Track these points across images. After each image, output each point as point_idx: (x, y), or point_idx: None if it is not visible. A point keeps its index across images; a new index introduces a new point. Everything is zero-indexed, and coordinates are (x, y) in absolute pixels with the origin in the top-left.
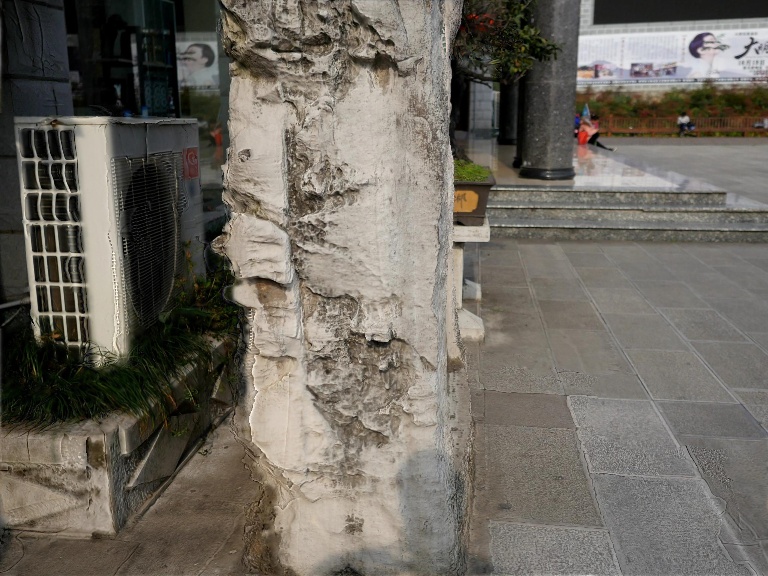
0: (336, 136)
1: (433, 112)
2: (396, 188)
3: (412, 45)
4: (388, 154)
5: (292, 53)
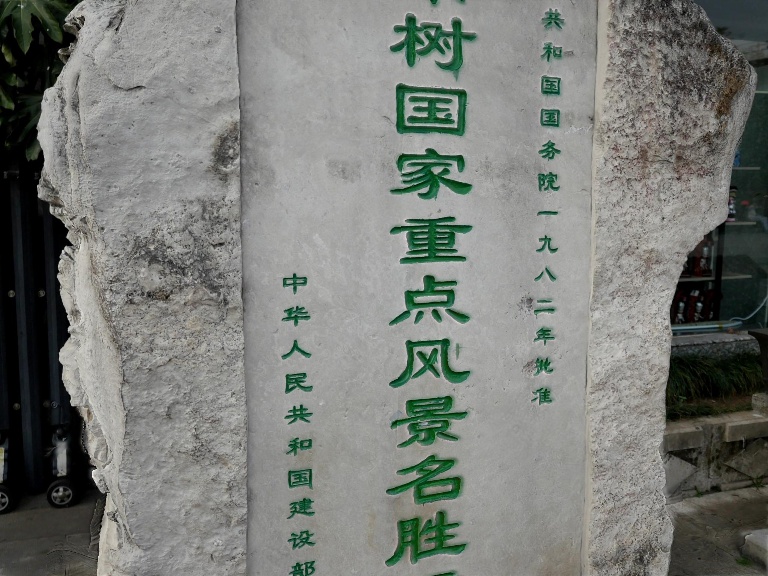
0: (76, 283)
1: (103, 271)
2: (95, 341)
3: (74, 205)
4: (90, 307)
5: (60, 208)
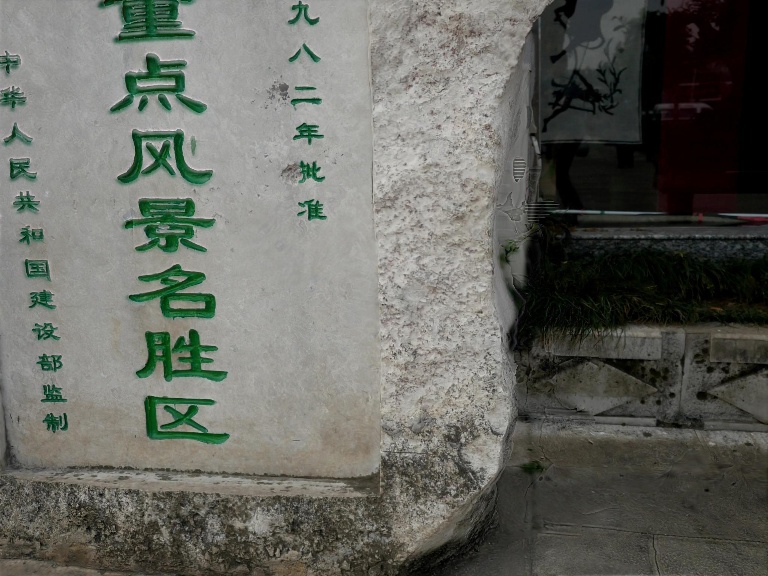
0: None
1: None
2: None
3: None
4: None
5: None
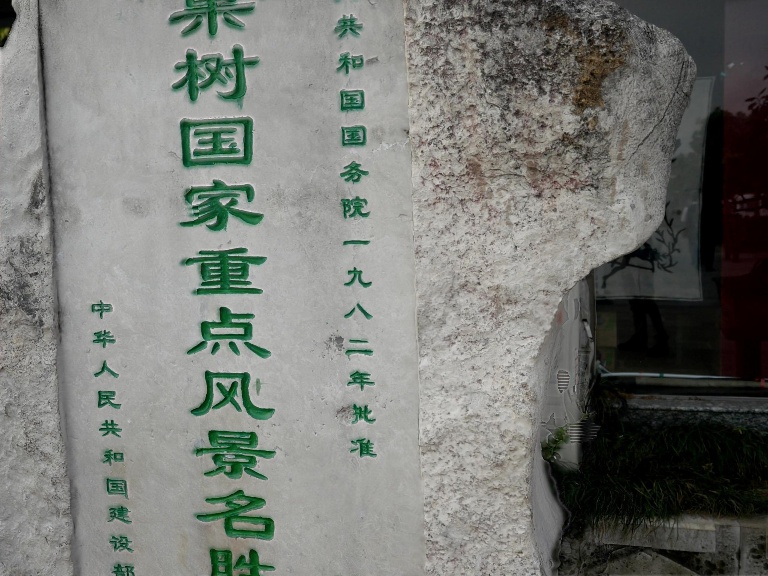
0: None
1: None
2: None
3: None
4: None
5: None
